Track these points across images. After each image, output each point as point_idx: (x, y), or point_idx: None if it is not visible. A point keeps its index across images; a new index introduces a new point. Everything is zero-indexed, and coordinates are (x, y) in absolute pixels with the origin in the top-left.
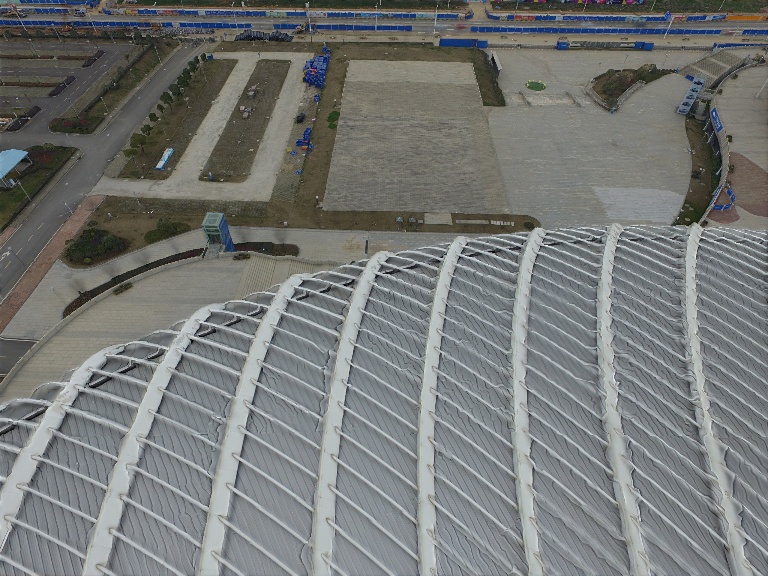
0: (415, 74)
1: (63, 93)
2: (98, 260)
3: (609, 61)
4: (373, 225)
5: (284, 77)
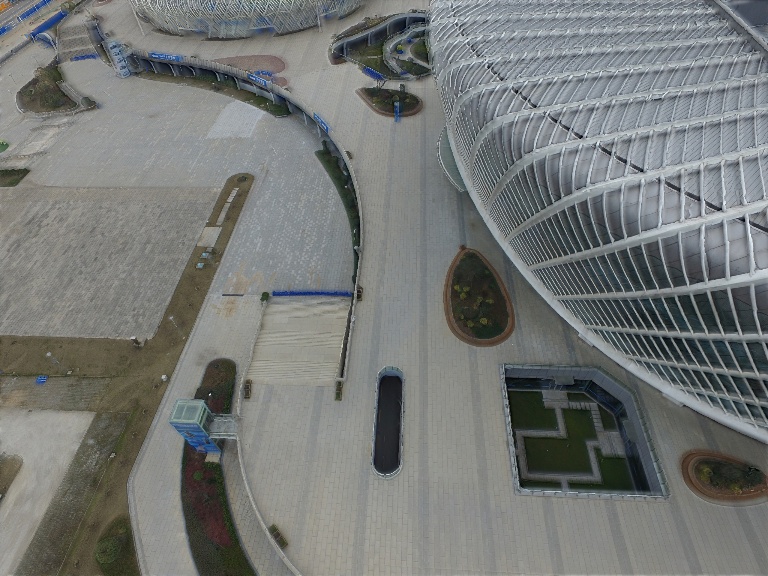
0: None
1: None
2: None
3: None
4: (199, 289)
5: None
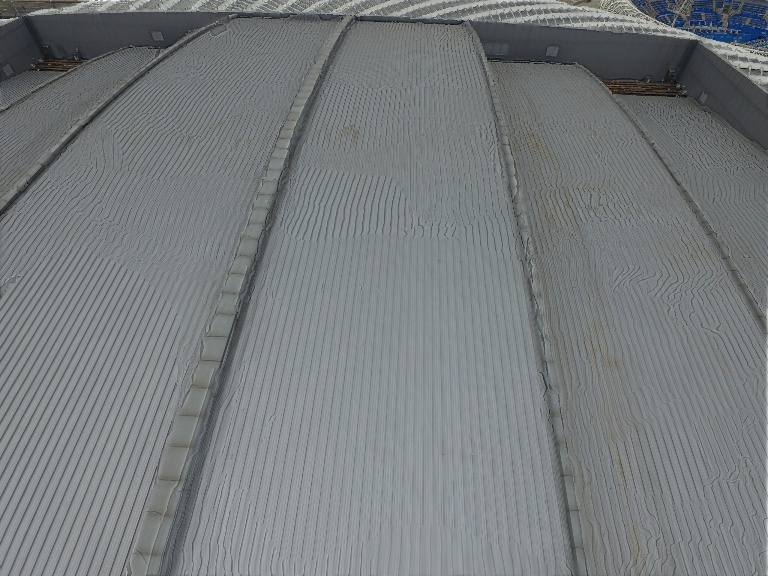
0: None
1: None
2: None
3: None
4: None
5: None
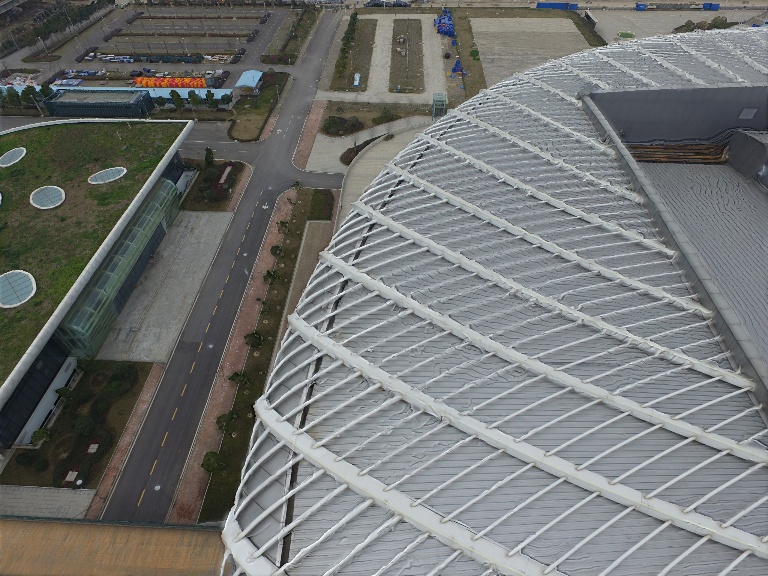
0: (527, 26)
1: (256, 41)
2: (347, 133)
3: (683, 18)
4: None
5: (420, 30)
